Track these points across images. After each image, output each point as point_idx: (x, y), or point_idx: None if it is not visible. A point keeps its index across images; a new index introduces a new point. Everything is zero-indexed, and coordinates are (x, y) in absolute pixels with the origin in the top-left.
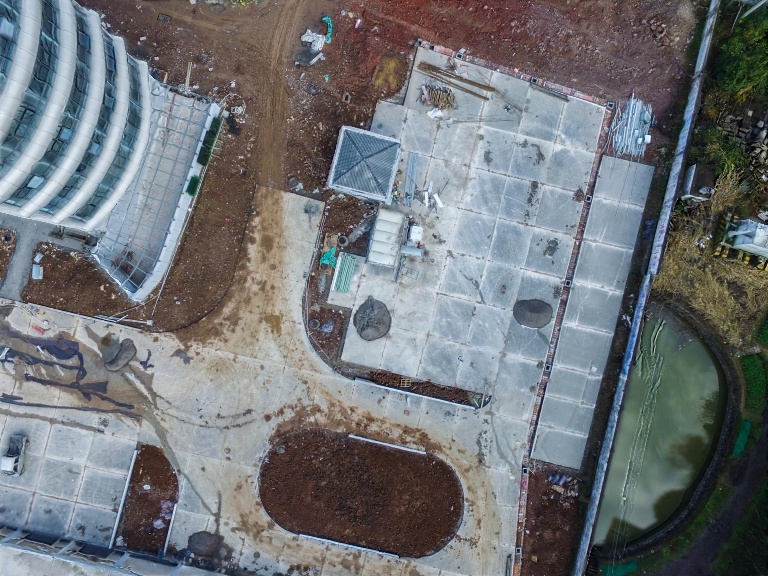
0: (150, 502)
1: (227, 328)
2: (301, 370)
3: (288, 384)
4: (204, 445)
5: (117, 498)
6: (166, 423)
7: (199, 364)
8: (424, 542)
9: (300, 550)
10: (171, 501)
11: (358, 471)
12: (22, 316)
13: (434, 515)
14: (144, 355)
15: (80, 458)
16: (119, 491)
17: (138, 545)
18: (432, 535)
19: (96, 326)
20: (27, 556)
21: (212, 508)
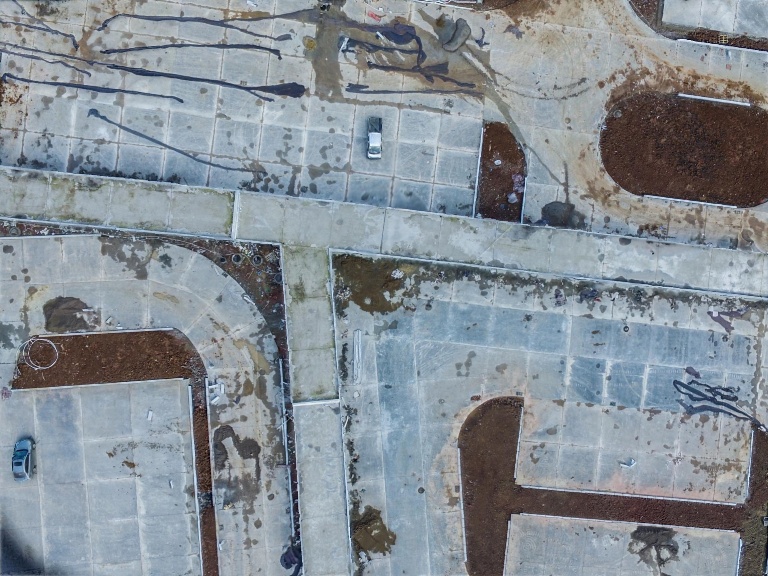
0: (502, 177)
1: (553, 0)
2: (626, 35)
3: (616, 50)
4: (545, 117)
5: (471, 176)
6: (507, 99)
7: (531, 38)
8: (759, 189)
9: (646, 210)
10: (521, 175)
11: (693, 126)
12: (357, 5)
13: (766, 162)
14: (479, 33)
15: (431, 140)
16: (472, 169)
17: (497, 219)
18: (766, 182)
19: (430, 8)
20: (416, 218)
21: (560, 178)
